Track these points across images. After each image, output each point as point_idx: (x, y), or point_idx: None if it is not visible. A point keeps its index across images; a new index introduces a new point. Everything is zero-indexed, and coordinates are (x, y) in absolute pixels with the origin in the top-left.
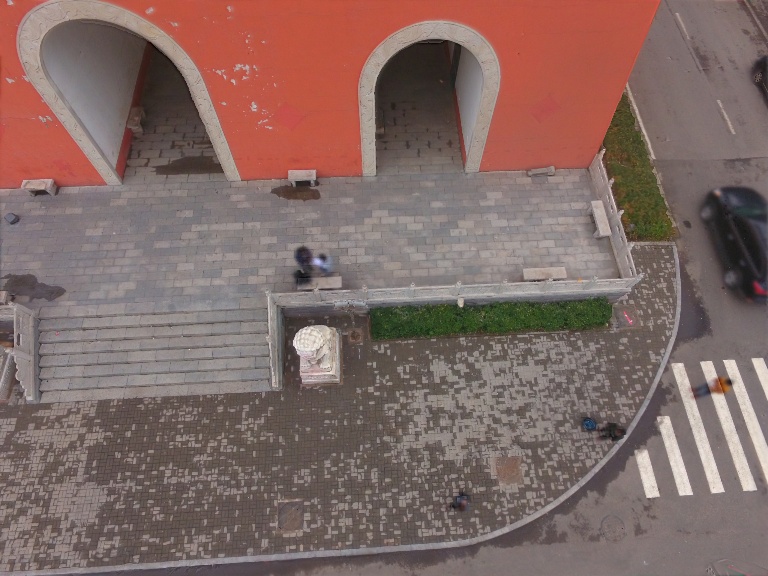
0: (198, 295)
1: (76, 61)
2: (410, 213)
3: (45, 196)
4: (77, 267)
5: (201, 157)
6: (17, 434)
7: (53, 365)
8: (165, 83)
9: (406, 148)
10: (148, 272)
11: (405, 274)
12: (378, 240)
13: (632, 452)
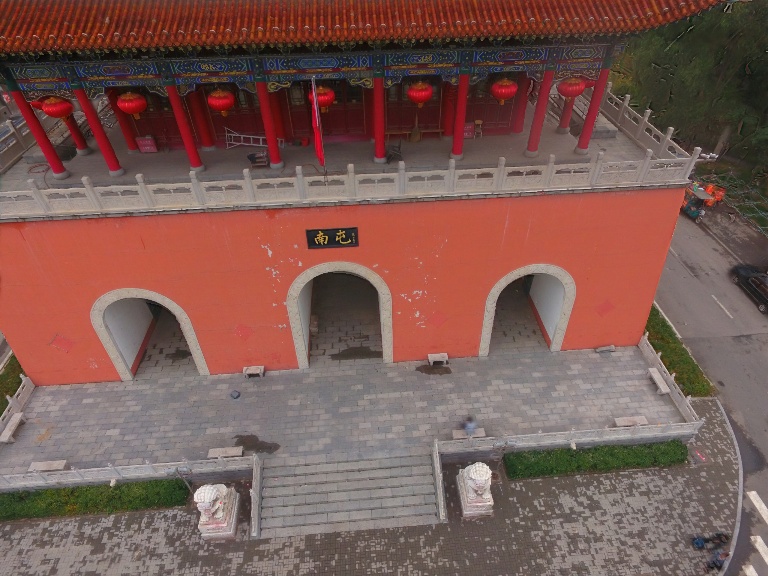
0: (378, 446)
1: (301, 291)
2: (519, 381)
3: (256, 378)
4: (286, 428)
5: (361, 347)
6: (245, 565)
7: (272, 506)
8: (328, 299)
9: (504, 336)
10: (338, 430)
11: (527, 426)
12: (501, 401)
13: (740, 568)
